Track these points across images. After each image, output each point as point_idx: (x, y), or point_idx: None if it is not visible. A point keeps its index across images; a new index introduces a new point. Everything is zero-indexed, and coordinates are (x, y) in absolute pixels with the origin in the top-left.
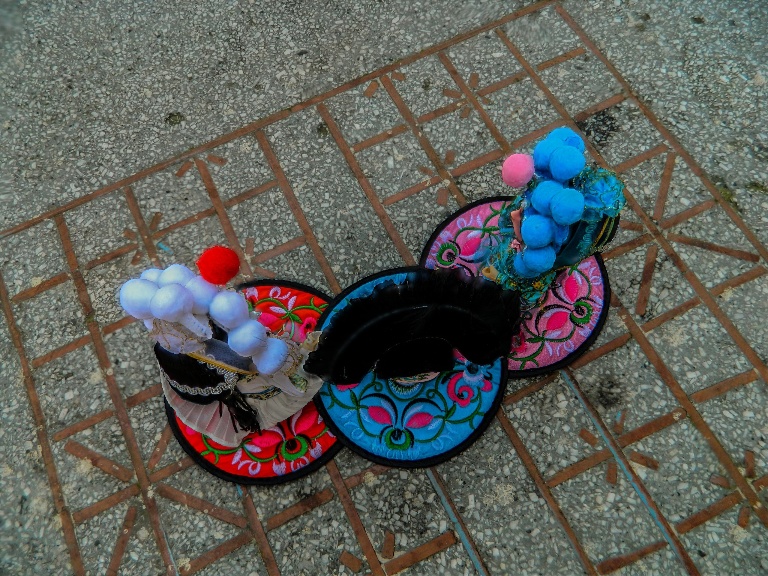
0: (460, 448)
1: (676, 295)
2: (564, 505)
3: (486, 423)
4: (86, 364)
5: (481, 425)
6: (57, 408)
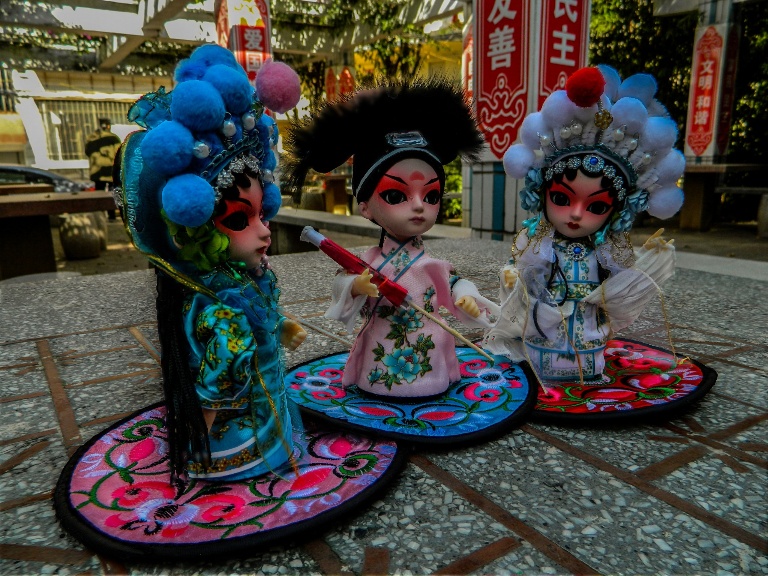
0: (335, 353)
1: None
2: None
3: (306, 362)
4: None
5: (312, 361)
6: None
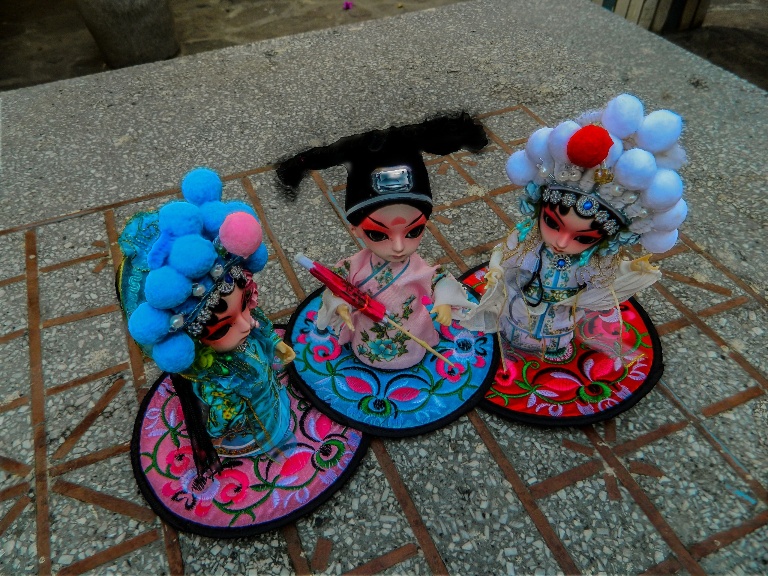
0: None
1: (69, 398)
2: (267, 245)
3: (319, 290)
4: (759, 357)
5: None
6: (763, 321)
